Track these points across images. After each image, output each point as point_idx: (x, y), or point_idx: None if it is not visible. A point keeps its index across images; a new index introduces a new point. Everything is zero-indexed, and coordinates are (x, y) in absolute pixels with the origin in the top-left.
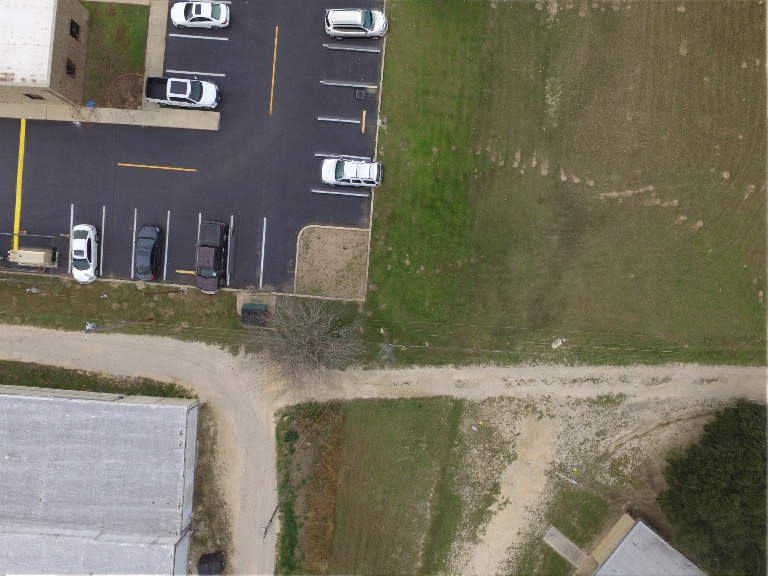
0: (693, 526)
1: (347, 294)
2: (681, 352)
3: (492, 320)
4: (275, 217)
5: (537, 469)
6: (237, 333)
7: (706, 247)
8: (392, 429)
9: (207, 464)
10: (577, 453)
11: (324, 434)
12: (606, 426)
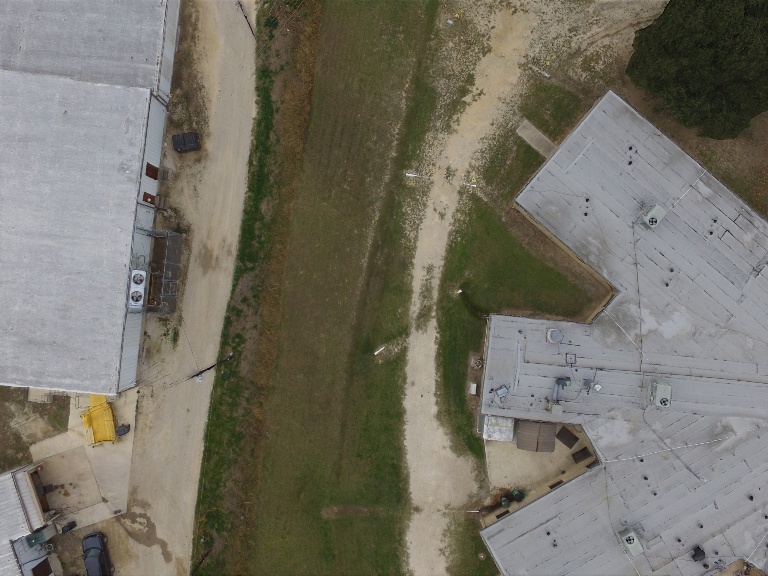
0: (659, 58)
1: None
2: None
3: None
4: None
5: (511, 62)
6: None
7: None
8: (370, 18)
9: (187, 49)
10: (550, 48)
11: (303, 18)
12: (578, 23)
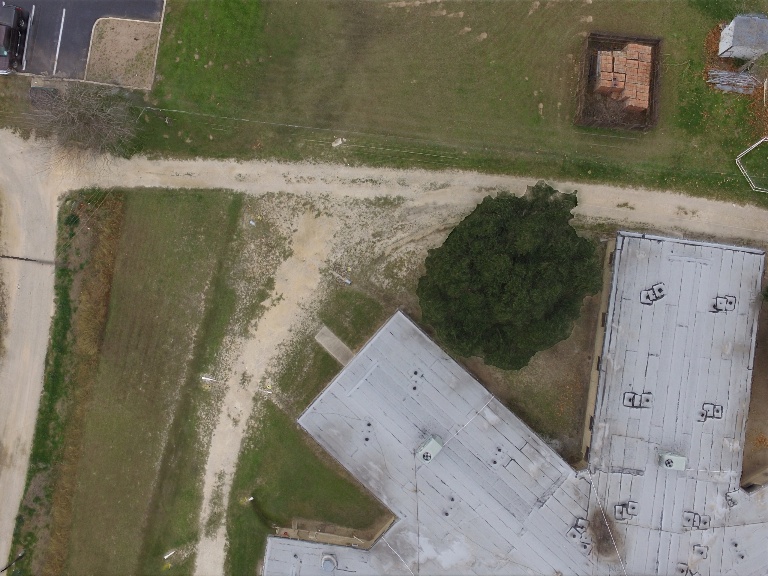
0: (432, 298)
1: (135, 82)
2: (460, 158)
3: (276, 117)
4: (74, 8)
5: (312, 266)
6: (28, 117)
7: (489, 58)
8: (171, 218)
9: None
10: (352, 253)
11: (103, 218)
12: (382, 228)
